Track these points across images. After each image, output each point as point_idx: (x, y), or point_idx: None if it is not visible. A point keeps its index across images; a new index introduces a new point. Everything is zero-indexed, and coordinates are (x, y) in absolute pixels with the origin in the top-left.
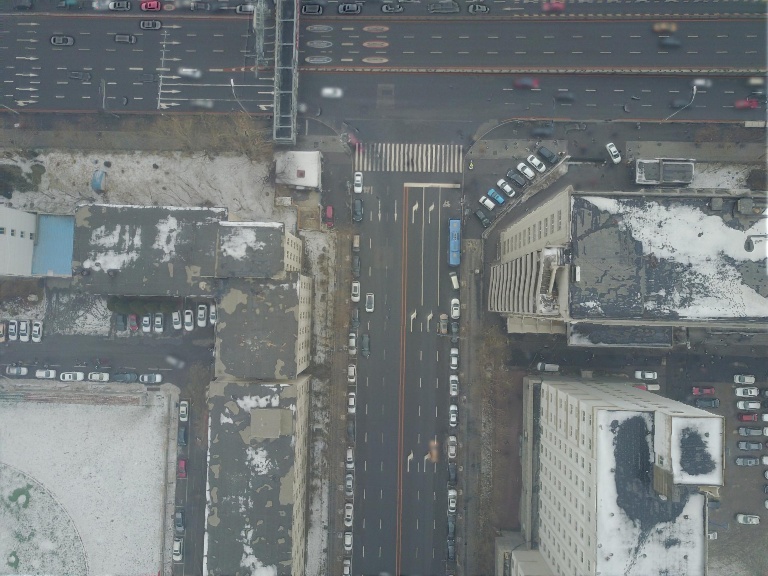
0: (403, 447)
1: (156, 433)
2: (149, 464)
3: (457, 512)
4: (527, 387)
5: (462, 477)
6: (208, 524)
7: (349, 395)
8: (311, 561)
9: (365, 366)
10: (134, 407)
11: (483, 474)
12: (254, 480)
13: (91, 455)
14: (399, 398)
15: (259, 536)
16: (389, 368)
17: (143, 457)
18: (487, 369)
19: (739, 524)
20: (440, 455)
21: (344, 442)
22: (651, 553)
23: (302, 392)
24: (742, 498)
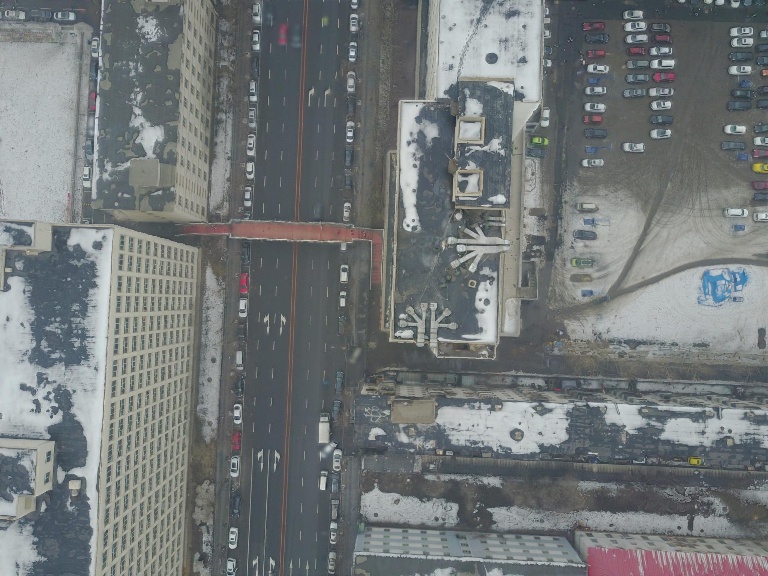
0: (305, 83)
1: (69, 69)
2: (62, 98)
3: (355, 143)
4: (418, 3)
5: (360, 111)
6: (100, 88)
7: (253, 32)
8: (215, 189)
9: (269, 5)
10: (49, 44)
11: (380, 108)
12: (144, 47)
13: (7, 89)
14: (302, 37)
15: (148, 98)
16: (293, 9)
17: (57, 92)
18: (386, 9)
19: (625, 153)
20: (339, 89)
21: (248, 78)
22: (492, 24)
23: (202, 7)
24: (629, 129)
